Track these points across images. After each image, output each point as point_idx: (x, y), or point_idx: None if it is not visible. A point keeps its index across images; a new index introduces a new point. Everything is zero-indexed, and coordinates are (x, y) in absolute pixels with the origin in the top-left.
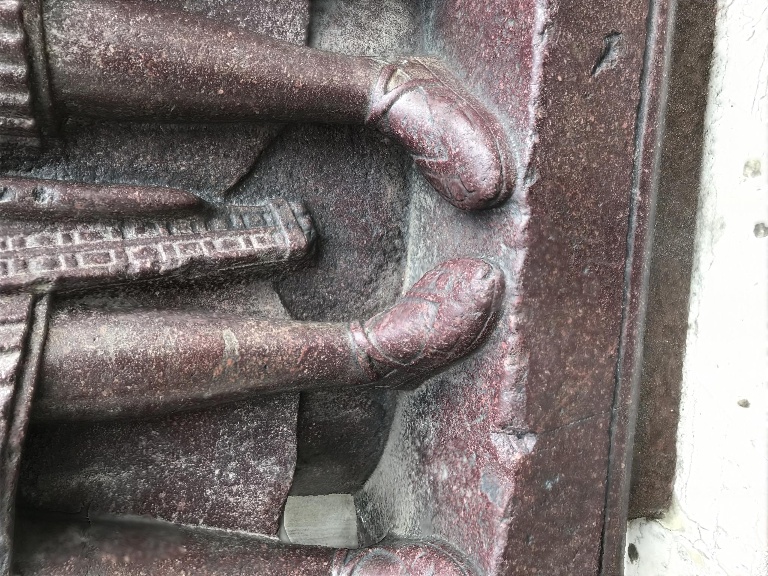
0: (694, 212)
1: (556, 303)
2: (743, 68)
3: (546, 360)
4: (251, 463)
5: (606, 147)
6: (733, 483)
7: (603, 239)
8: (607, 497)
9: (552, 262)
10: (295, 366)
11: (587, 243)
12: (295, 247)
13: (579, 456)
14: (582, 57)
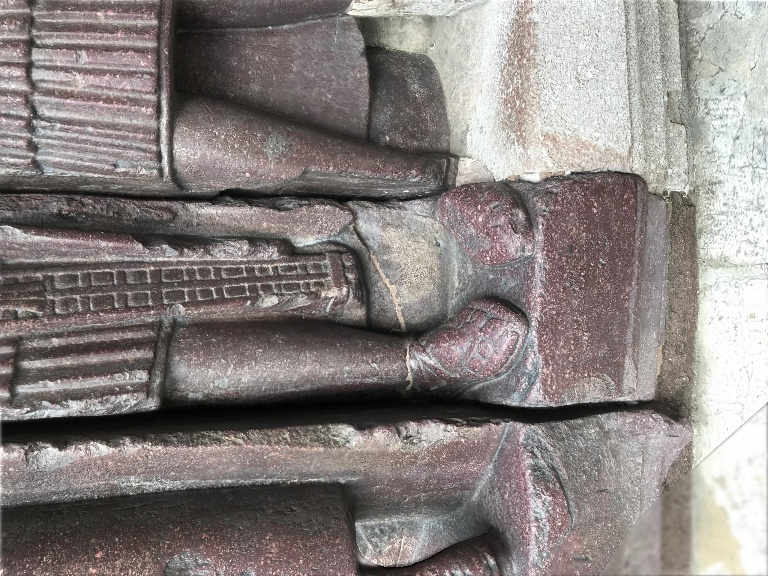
0: None
1: None
2: None
3: None
4: None
5: None
6: None
7: None
8: None
9: None
10: None
11: None
12: None
13: None
14: None
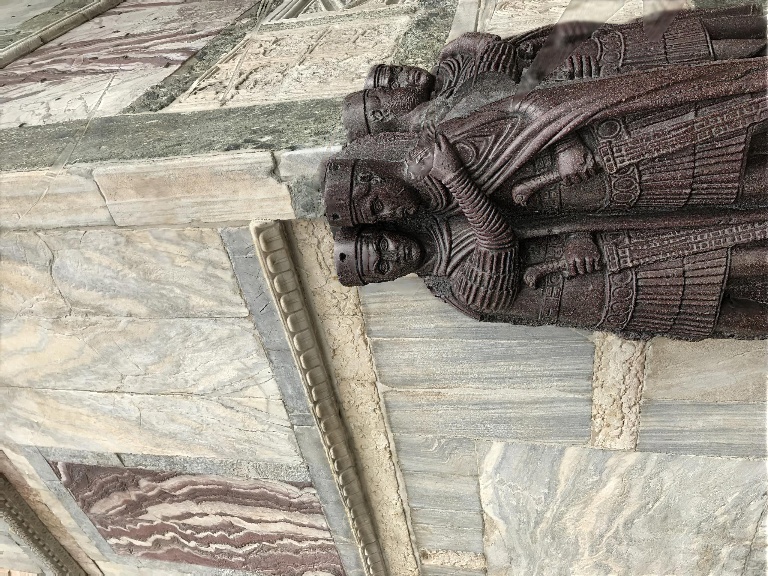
0: None
1: None
2: None
3: None
4: None
5: None
6: None
7: None
8: None
9: None
10: None
11: None
12: None
13: None
14: None
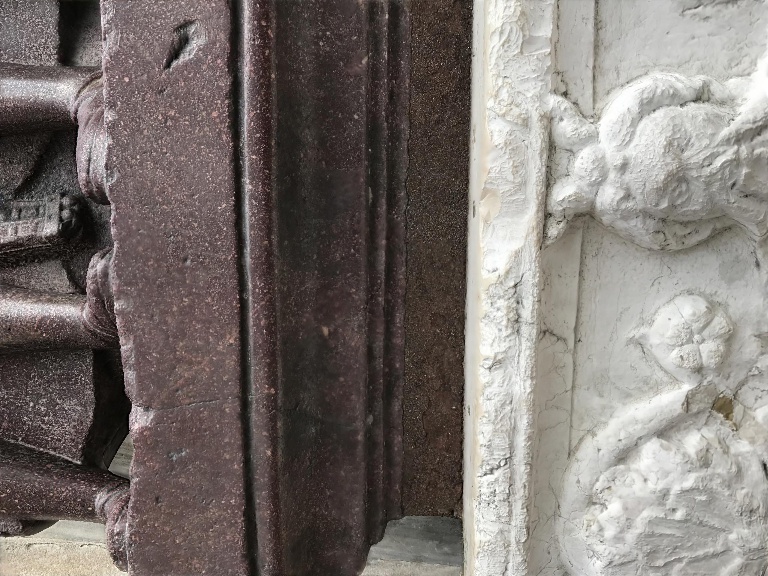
0: (465, 184)
1: (157, 292)
2: (476, 7)
3: (153, 343)
4: (58, 402)
5: (195, 138)
6: (468, 497)
7: (204, 230)
8: (251, 480)
9: (147, 253)
10: (34, 330)
11: (186, 234)
12: (47, 234)
13: (205, 436)
14: (150, 53)
